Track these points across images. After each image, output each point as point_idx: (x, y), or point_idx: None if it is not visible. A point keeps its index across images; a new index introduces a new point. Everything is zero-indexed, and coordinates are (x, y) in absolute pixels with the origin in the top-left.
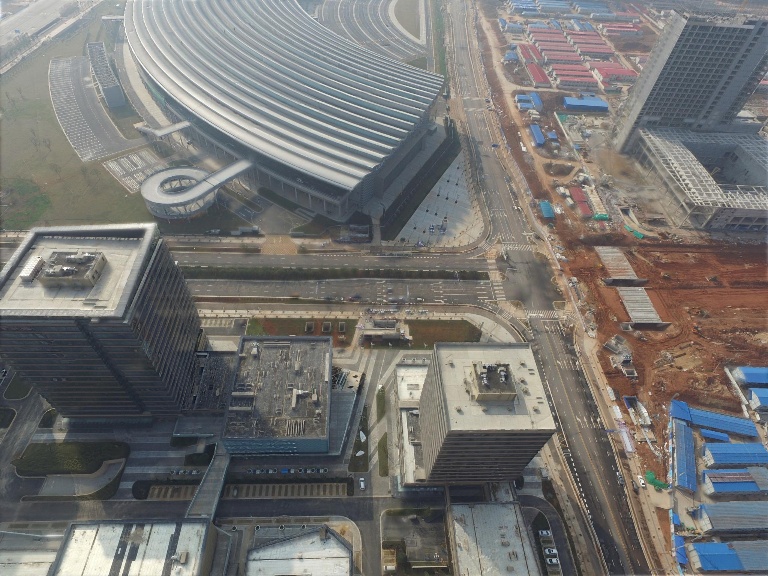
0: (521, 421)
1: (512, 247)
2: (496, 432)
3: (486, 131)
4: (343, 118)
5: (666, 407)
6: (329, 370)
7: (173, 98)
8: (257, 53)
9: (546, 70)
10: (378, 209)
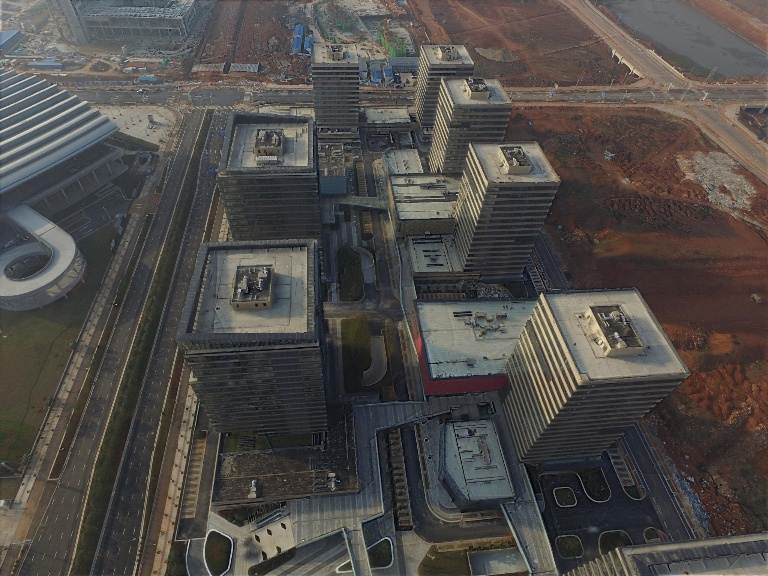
0: (352, 51)
1: None
2: None
3: None
4: None
5: None
6: None
7: None
8: None
9: None
10: None
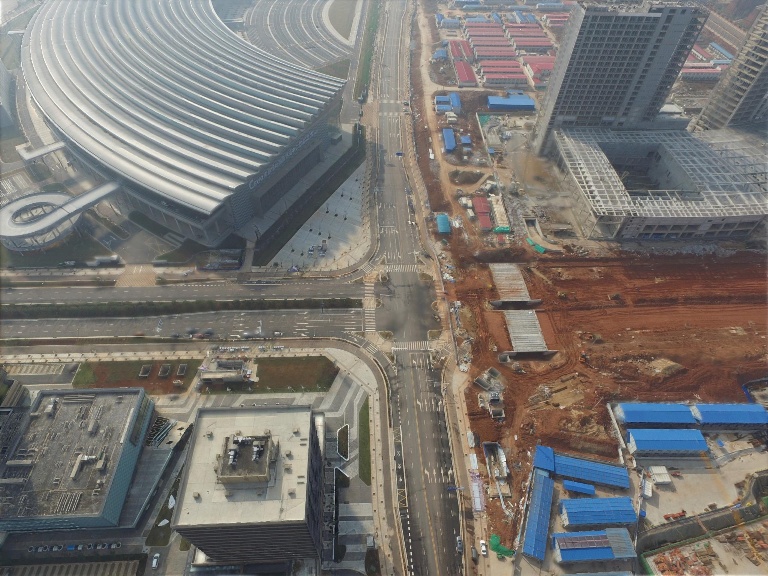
0: (268, 509)
1: (391, 269)
2: (233, 525)
3: (397, 137)
4: (217, 133)
5: (531, 454)
6: (127, 429)
7: (47, 117)
8: (143, 65)
9: (475, 67)
10: None
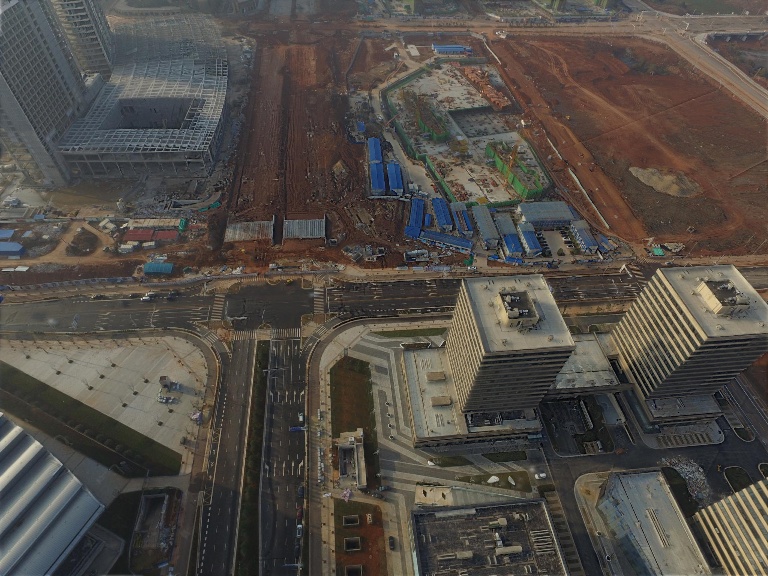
0: (542, 296)
1: None
2: None
3: None
4: None
5: (408, 239)
6: (462, 508)
7: None
8: None
9: None
10: (101, 483)
